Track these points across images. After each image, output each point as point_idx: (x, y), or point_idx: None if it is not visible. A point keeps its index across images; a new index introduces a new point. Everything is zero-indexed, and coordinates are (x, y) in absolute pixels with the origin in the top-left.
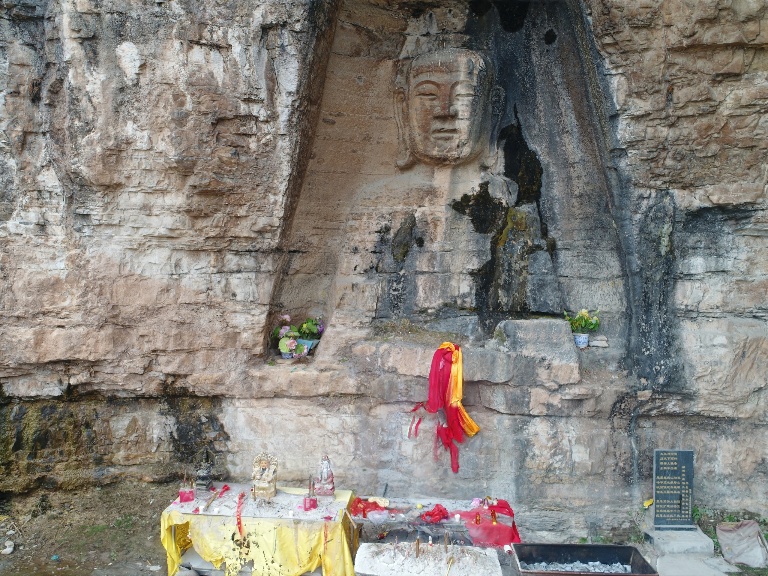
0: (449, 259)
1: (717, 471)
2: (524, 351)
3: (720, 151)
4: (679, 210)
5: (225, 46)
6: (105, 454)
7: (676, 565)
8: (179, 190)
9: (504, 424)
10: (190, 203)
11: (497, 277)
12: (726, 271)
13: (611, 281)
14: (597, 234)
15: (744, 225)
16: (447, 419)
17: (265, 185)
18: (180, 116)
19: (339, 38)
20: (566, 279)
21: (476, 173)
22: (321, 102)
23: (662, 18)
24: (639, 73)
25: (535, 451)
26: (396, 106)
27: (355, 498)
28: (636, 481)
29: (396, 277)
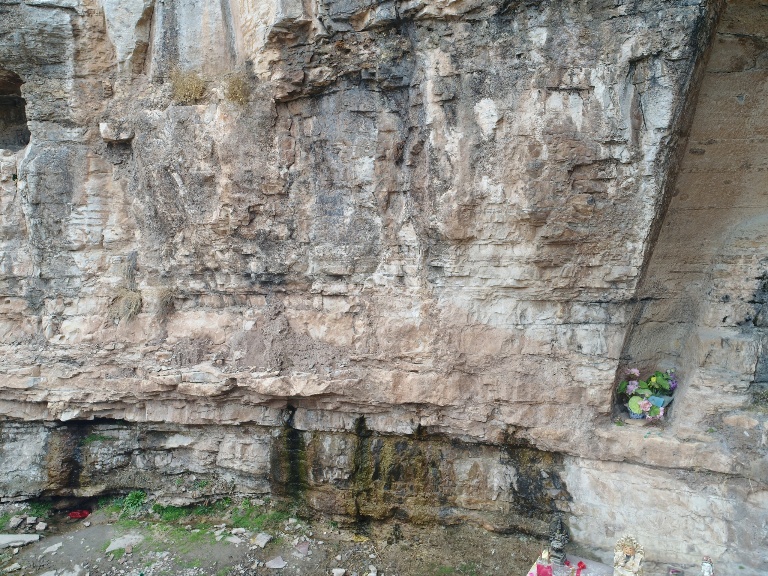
0: None
1: None
2: None
3: None
4: None
5: (586, 88)
6: (449, 495)
7: None
8: (529, 241)
9: None
10: (540, 254)
11: None
12: None
13: None
14: None
15: None
16: None
17: (623, 232)
18: (535, 167)
19: (716, 54)
20: None
21: None
22: (689, 131)
23: None
24: None
25: None
26: None
27: None
28: None
29: None
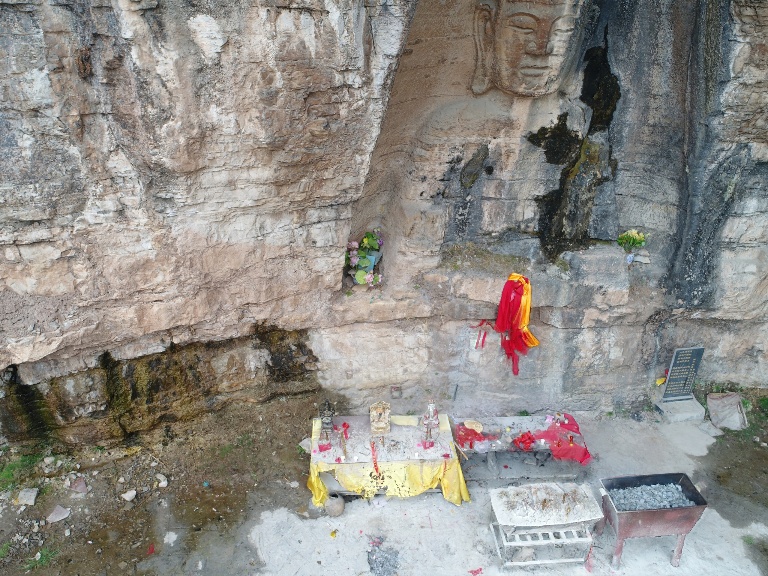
0: (518, 188)
1: (715, 355)
2: (585, 282)
3: None
4: (751, 160)
5: (319, 10)
6: (211, 387)
7: (679, 433)
8: (266, 164)
9: (559, 337)
10: (278, 176)
11: (563, 207)
12: None
13: (664, 206)
14: (660, 161)
15: None
16: (511, 335)
17: (353, 148)
18: (270, 96)
19: None
20: (620, 197)
21: (554, 101)
22: None
23: None
24: (767, 46)
25: (581, 354)
26: (476, 23)
27: (455, 426)
28: (653, 367)
29: (462, 202)
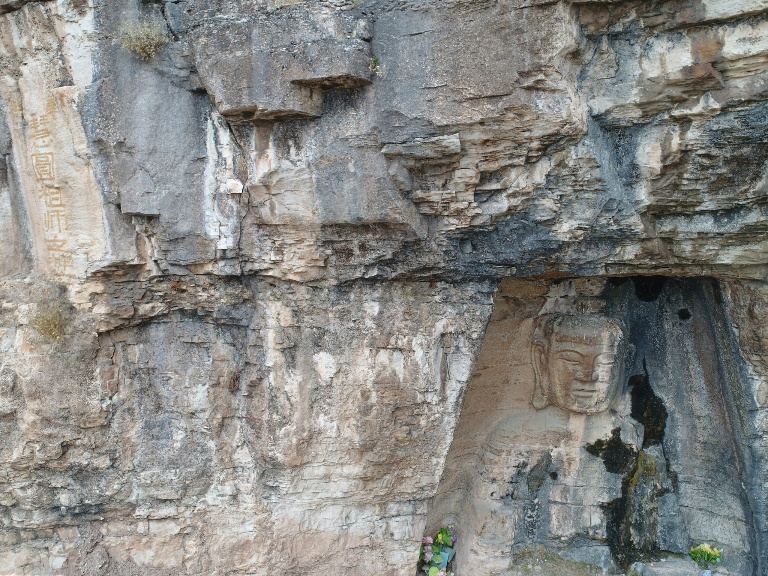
0: (582, 494)
1: None
2: None
3: None
4: None
5: (408, 349)
6: None
7: None
8: (357, 462)
9: None
10: (365, 472)
11: (628, 515)
12: None
13: (732, 521)
14: (719, 476)
15: None
16: None
17: (430, 452)
18: (366, 409)
19: None
20: (686, 509)
21: (607, 417)
22: None
23: None
24: None
25: None
26: (533, 354)
27: None
28: None
29: (530, 505)
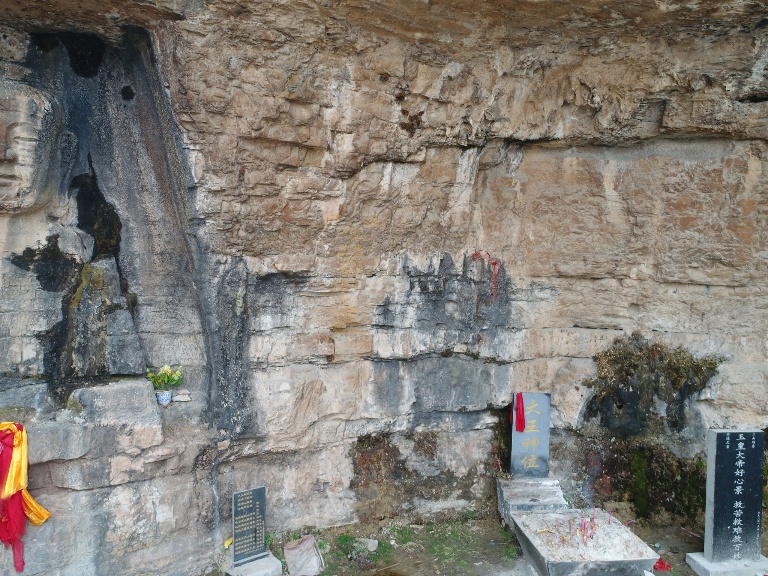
0: (8, 321)
1: (284, 498)
2: (103, 420)
3: (283, 227)
4: (251, 275)
5: None
6: None
7: None
8: None
9: (81, 502)
10: None
11: (70, 340)
12: (289, 326)
13: (192, 336)
14: (179, 291)
15: (301, 288)
16: (8, 512)
17: None
18: None
19: None
20: (148, 335)
21: (42, 223)
22: None
23: (234, 109)
24: (215, 153)
25: (117, 522)
26: None
27: None
28: (217, 525)
29: None
